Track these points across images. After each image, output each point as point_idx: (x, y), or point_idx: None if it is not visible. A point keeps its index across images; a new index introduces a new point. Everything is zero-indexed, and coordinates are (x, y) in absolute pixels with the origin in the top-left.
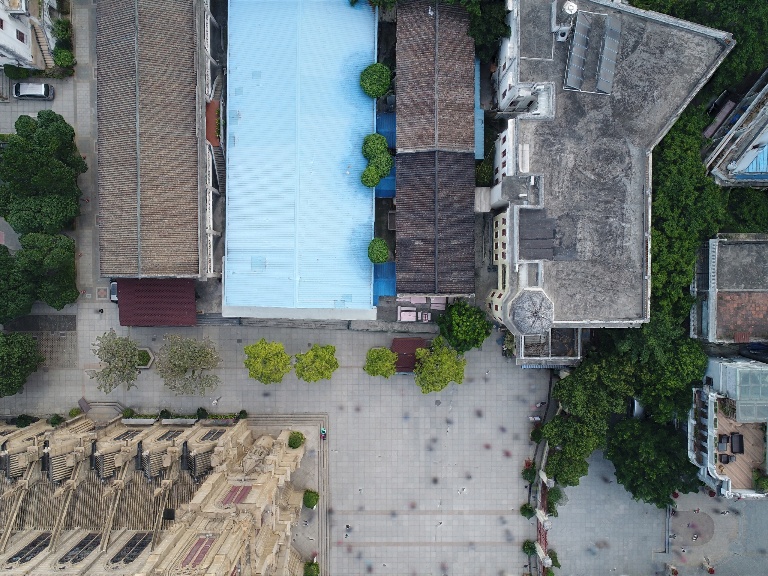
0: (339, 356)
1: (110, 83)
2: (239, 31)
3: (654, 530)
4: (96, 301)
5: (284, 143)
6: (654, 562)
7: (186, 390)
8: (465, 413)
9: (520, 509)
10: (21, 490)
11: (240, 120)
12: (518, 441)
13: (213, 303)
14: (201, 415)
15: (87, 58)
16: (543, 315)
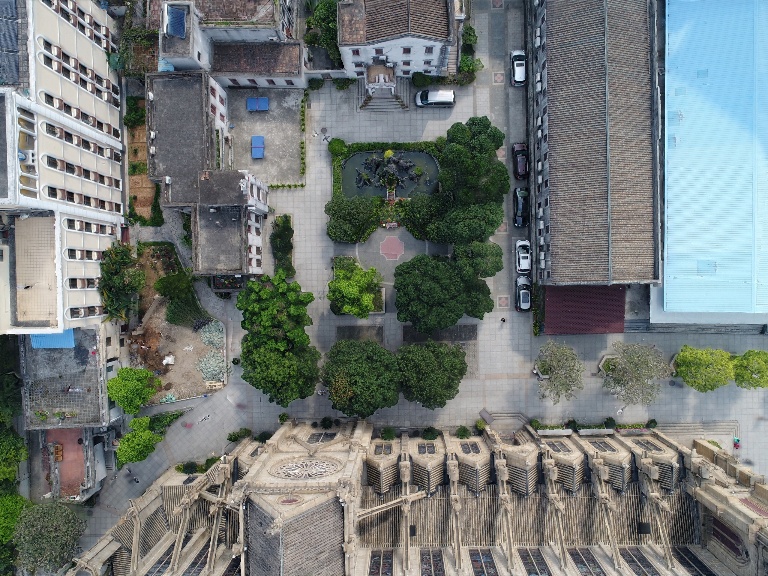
0: None
1: (567, 86)
2: (680, 30)
3: None
4: (497, 310)
5: (738, 143)
6: None
7: None
8: None
9: None
10: None
11: (682, 121)
12: None
13: None
14: (610, 425)
15: (487, 63)
16: None
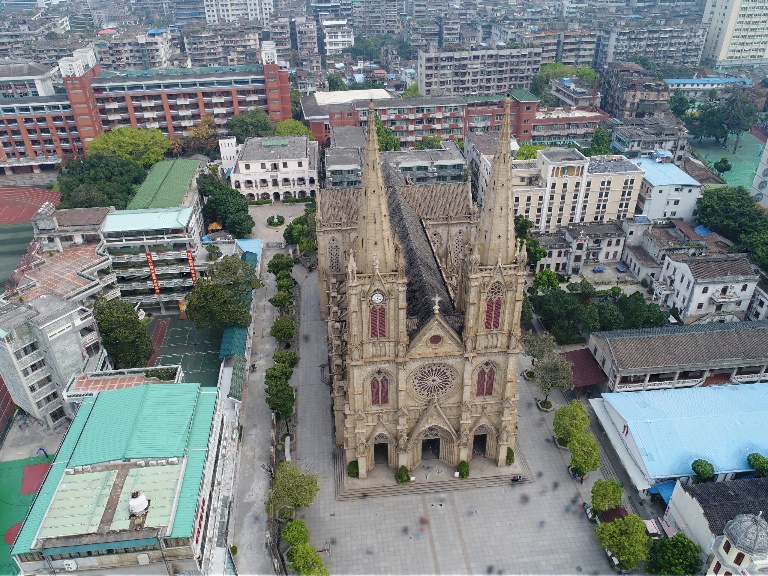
0: (586, 486)
1: None
2: None
3: None
4: None
5: (739, 407)
6: None
7: (533, 379)
8: None
9: None
10: None
11: (734, 390)
12: None
13: (588, 405)
14: None
15: None
16: (759, 524)
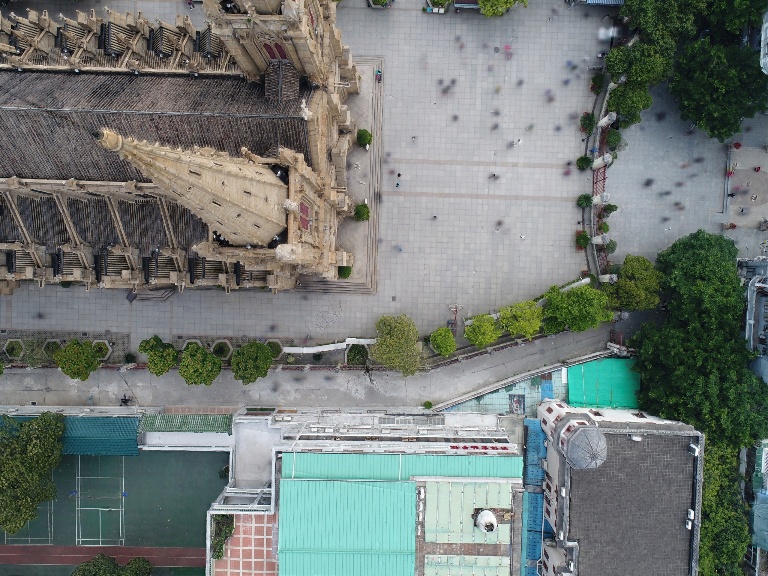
0: None
1: None
2: None
3: (712, 189)
4: None
5: None
6: (711, 223)
7: None
8: (524, 61)
9: (576, 162)
10: (79, 48)
11: None
12: (577, 93)
13: None
14: None
15: None
16: None
